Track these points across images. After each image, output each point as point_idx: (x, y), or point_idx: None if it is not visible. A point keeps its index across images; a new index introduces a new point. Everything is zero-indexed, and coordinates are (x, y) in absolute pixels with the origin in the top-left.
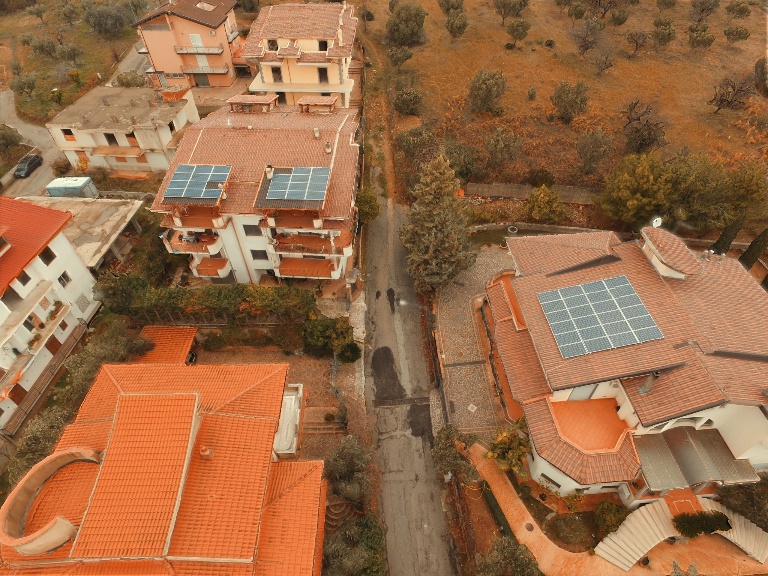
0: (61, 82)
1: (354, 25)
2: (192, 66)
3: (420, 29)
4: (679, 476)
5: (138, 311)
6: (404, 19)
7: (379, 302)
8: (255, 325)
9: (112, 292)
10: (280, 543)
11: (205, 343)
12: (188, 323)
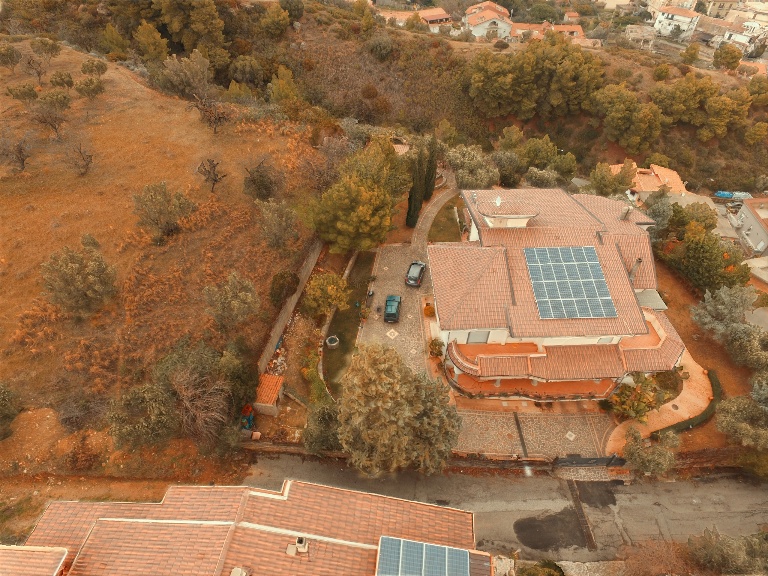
0: None
1: None
2: None
3: None
4: (650, 291)
5: None
6: None
7: None
8: None
9: None
10: None
11: None
12: None
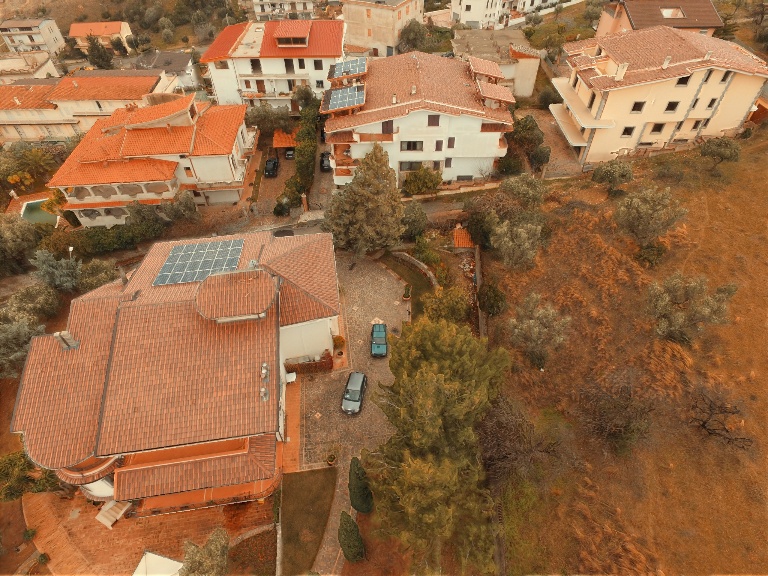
0: None
1: (671, 74)
2: None
3: None
4: None
5: None
6: None
7: None
8: None
9: (298, 93)
10: (131, 169)
11: None
12: None
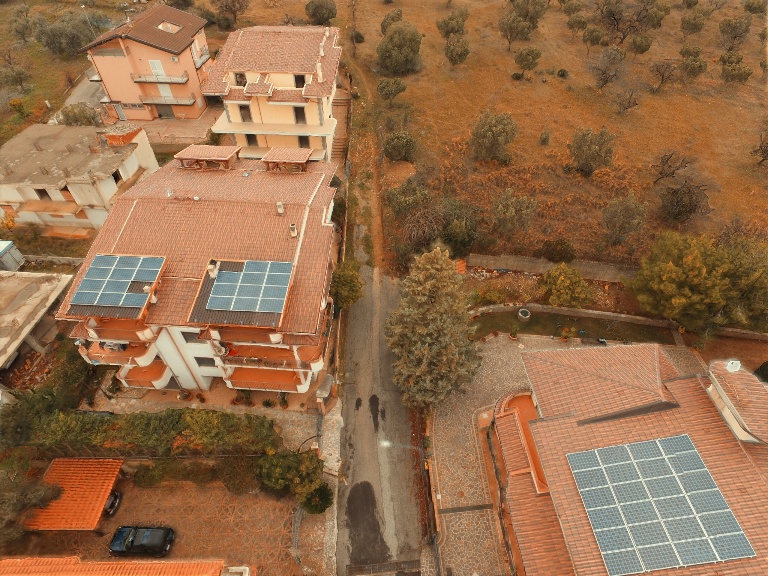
0: (3, 111)
1: (337, 56)
2: (153, 96)
3: (415, 55)
4: None
5: (42, 444)
6: (397, 44)
7: (359, 415)
8: (197, 457)
9: None
10: None
11: (134, 477)
12: (110, 455)
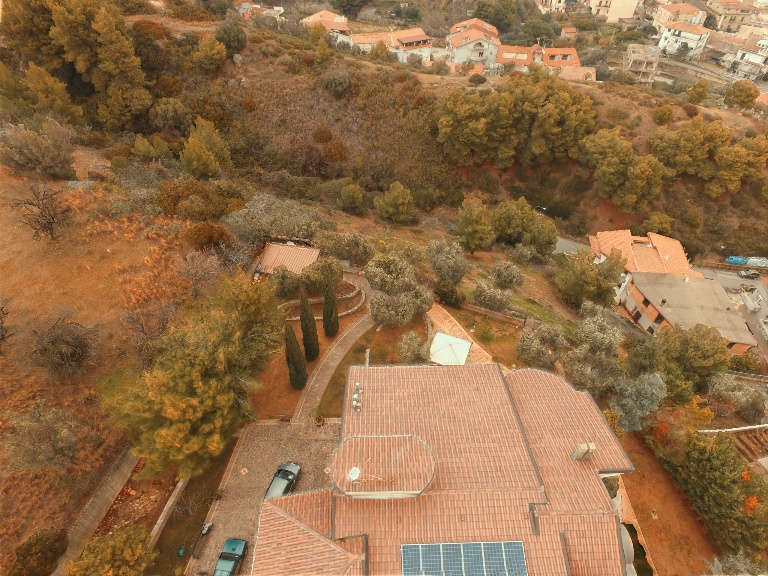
0: None
1: None
2: None
3: None
4: None
5: None
6: None
7: None
8: None
9: None
10: None
11: None
12: None
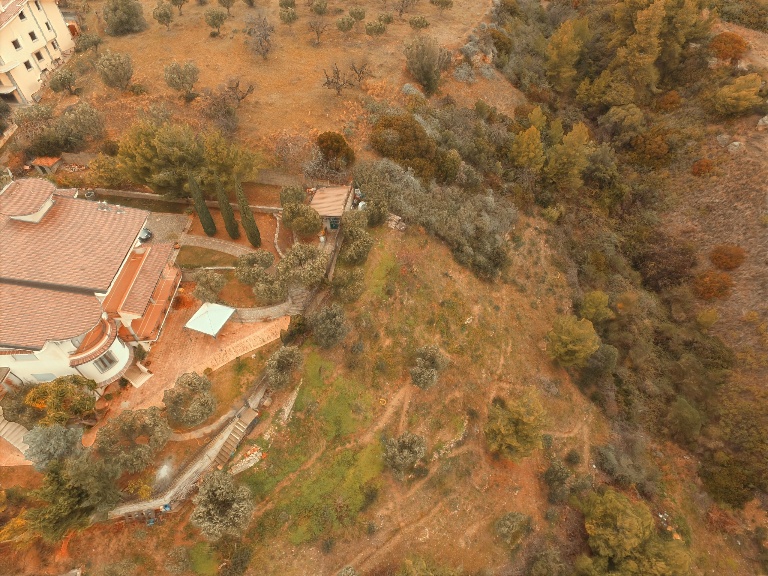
0: None
1: (14, 12)
2: None
3: (136, 18)
4: None
5: None
6: (113, 8)
7: None
8: None
9: None
10: None
11: None
12: None
